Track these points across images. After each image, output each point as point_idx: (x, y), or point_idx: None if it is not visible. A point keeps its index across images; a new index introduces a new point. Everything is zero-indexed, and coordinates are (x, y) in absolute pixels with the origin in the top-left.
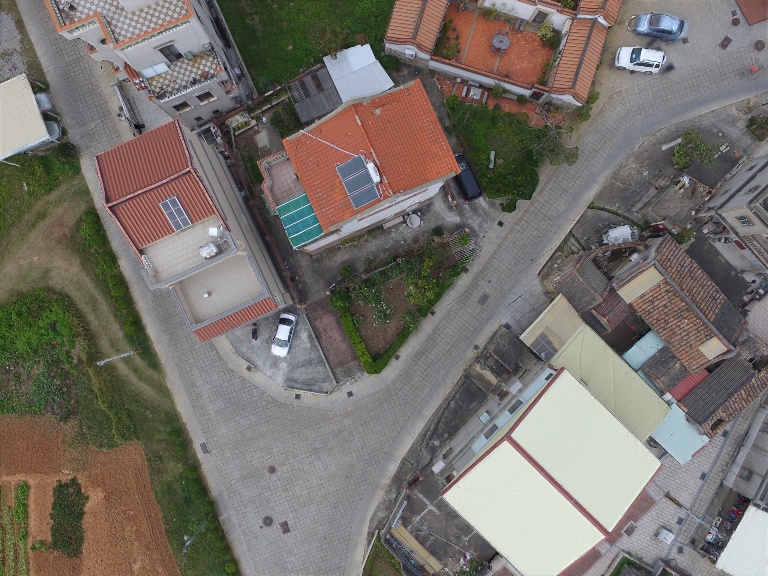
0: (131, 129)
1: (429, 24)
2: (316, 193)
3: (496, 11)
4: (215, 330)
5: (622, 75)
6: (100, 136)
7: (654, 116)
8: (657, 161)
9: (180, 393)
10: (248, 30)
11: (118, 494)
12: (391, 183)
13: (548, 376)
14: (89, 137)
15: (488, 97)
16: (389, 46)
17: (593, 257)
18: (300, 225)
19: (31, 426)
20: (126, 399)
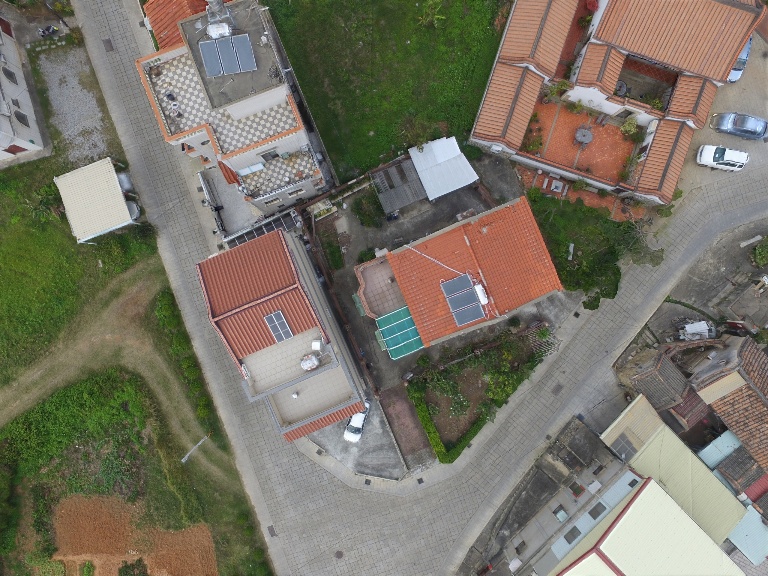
0: (209, 210)
1: (518, 122)
2: (418, 307)
3: (581, 106)
4: (303, 431)
5: (702, 171)
6: (178, 216)
7: (733, 213)
8: (735, 257)
9: (249, 475)
10: (330, 115)
11: (184, 575)
12: (497, 303)
13: (632, 482)
14: (167, 217)
15: (568, 189)
16: (475, 140)
17: (672, 355)
18: (400, 337)
19: (99, 506)
20: (195, 480)
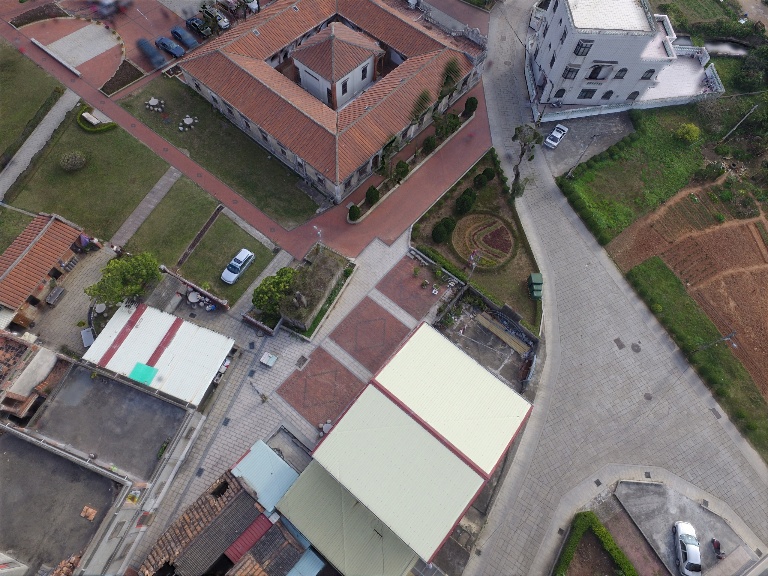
0: None
1: None
2: None
3: None
4: None
5: None
6: None
7: None
8: None
9: (760, 469)
10: None
11: None
12: None
13: None
14: None
15: None
16: None
17: None
18: None
19: None
20: None
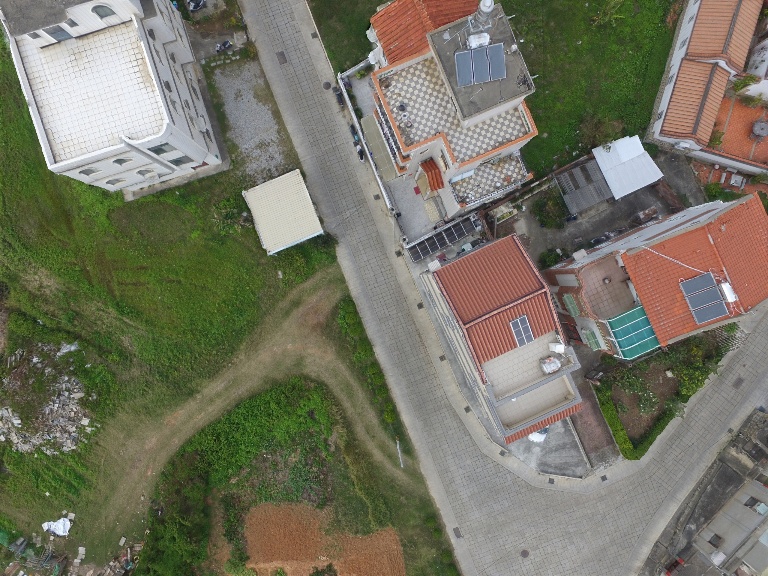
0: (386, 217)
1: (707, 118)
2: (655, 307)
3: (760, 100)
4: (522, 433)
5: None
6: (355, 224)
7: None
8: None
9: (434, 478)
10: None
11: None
12: (741, 300)
13: None
14: (344, 225)
15: (745, 183)
16: (659, 137)
17: None
18: (635, 337)
19: (288, 513)
20: (381, 485)
